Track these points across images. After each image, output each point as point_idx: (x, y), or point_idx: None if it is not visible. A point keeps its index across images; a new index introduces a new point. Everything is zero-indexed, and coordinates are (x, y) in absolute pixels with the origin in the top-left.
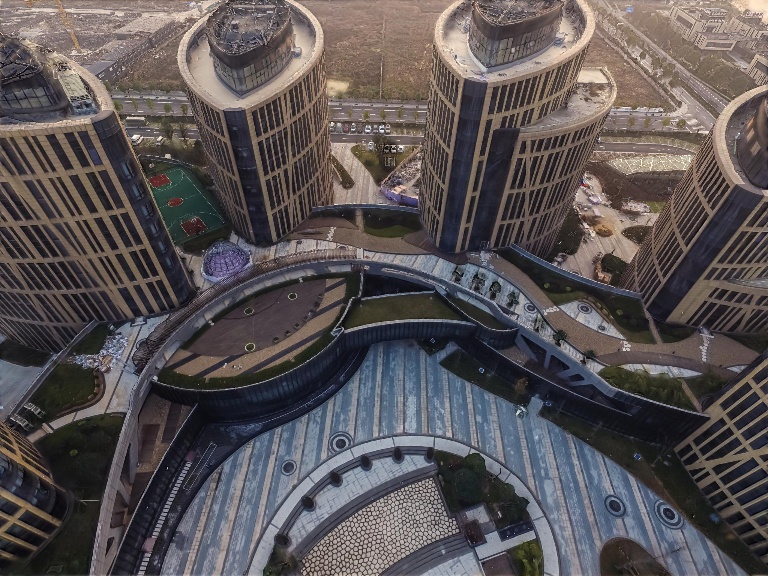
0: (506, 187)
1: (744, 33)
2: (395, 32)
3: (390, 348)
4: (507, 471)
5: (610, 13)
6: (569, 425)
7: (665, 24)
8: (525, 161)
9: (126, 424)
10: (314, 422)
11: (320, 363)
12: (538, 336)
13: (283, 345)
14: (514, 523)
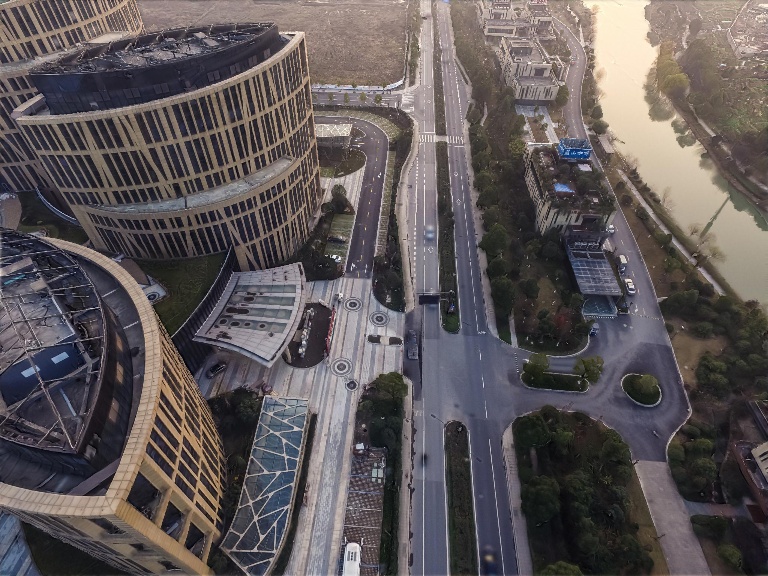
0: None
1: (528, 19)
2: (208, 21)
3: None
4: None
5: (434, 4)
6: None
7: (459, 12)
8: None
9: None
10: None
11: None
12: None
13: None
14: None
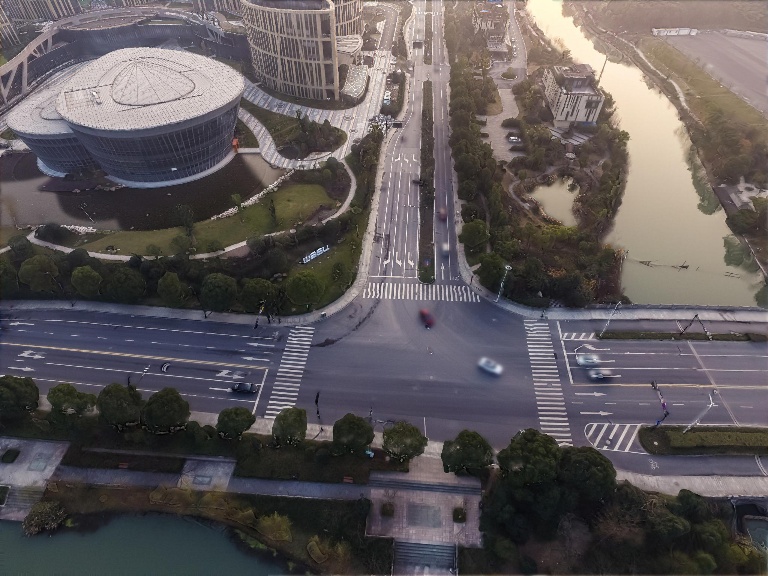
0: None
1: None
2: None
3: None
4: None
5: None
6: None
7: None
8: None
9: (46, 31)
10: None
11: (125, 33)
12: (209, 24)
13: None
14: None
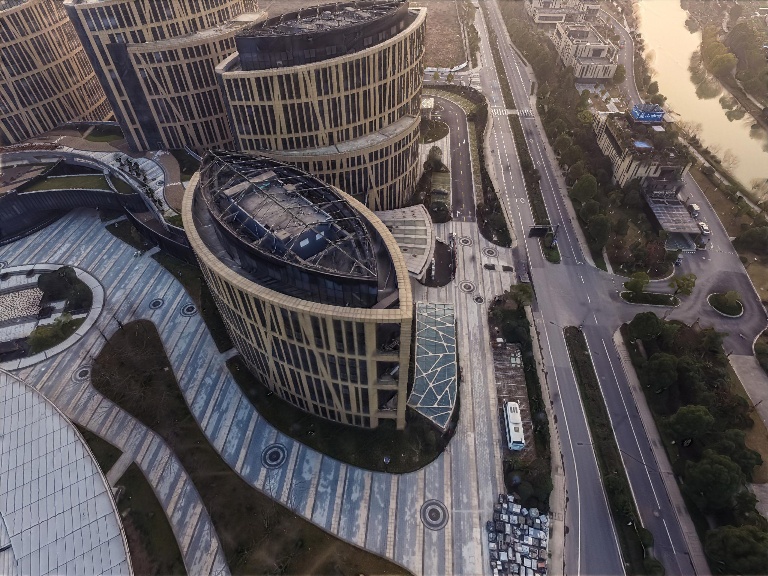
0: (145, 93)
1: (576, 7)
2: (272, 13)
3: (77, 217)
4: (98, 284)
5: None
6: (166, 262)
7: (509, 1)
8: (147, 71)
9: None
10: None
11: None
12: (144, 196)
13: None
14: (77, 309)
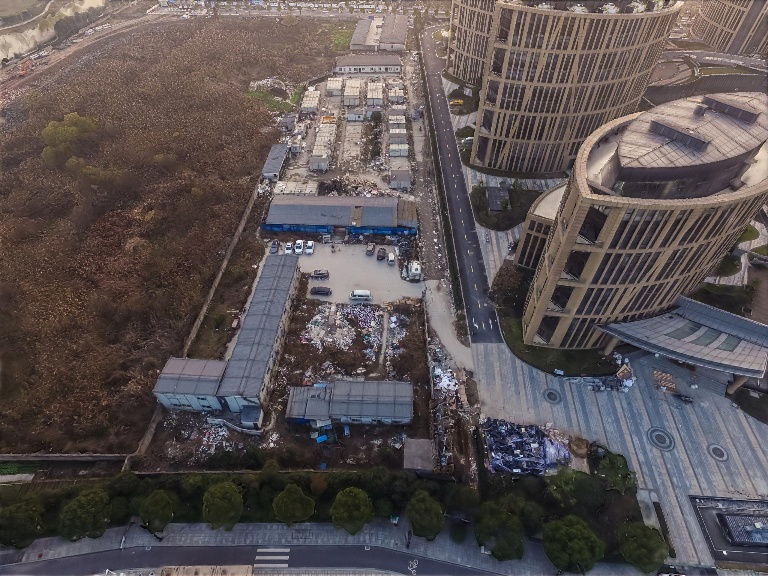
0: None
1: None
2: None
3: None
4: None
5: None
6: None
7: None
8: None
9: None
10: None
11: None
12: None
13: (675, 79)
14: None
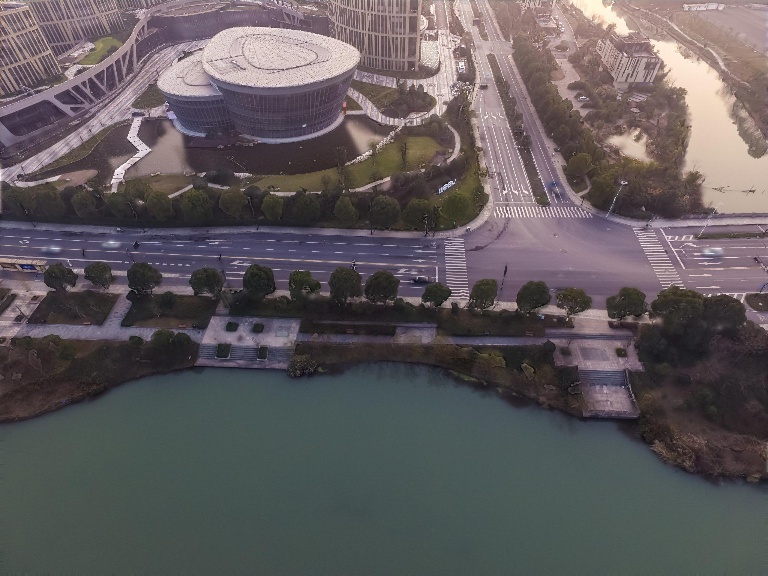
0: None
1: None
2: None
3: None
4: None
5: None
6: None
7: None
8: None
9: (143, 18)
10: (208, 40)
11: (210, 19)
12: (286, 8)
13: (197, 13)
14: None
